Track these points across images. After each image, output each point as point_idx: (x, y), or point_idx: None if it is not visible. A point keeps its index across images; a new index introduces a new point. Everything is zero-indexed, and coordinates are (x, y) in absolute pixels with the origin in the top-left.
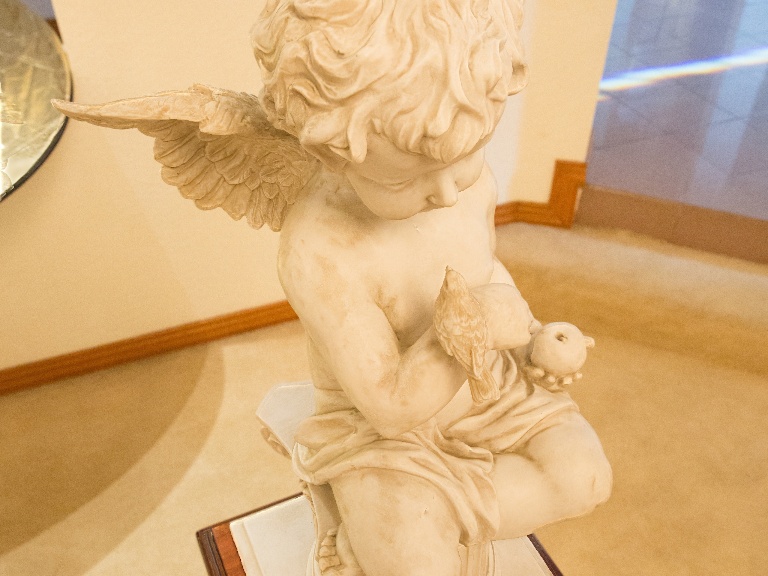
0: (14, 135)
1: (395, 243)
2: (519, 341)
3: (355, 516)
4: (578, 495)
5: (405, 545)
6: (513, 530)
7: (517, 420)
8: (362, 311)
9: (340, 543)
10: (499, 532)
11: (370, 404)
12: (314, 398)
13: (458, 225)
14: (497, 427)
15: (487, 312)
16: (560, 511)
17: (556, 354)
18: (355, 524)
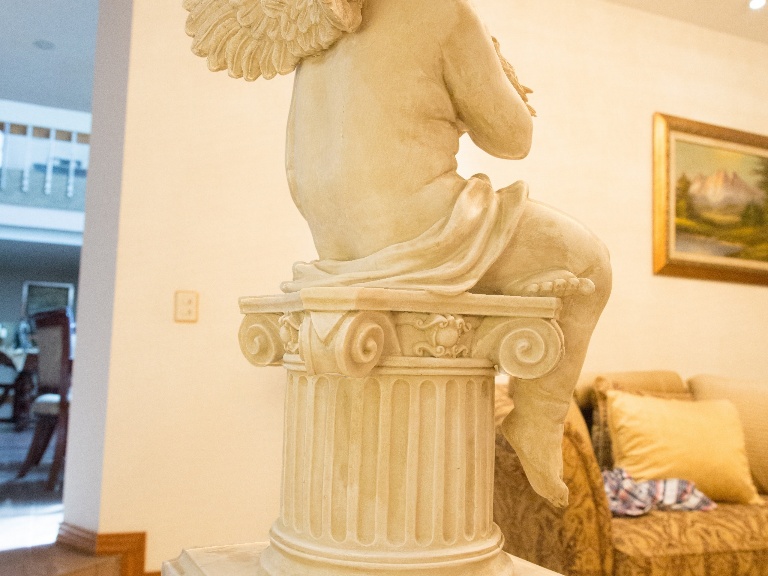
0: None
1: None
2: None
3: (560, 219)
4: None
5: None
6: None
7: None
8: None
9: (552, 275)
10: None
11: (529, 113)
12: (434, 194)
13: None
14: None
15: None
16: None
17: None
18: (564, 224)
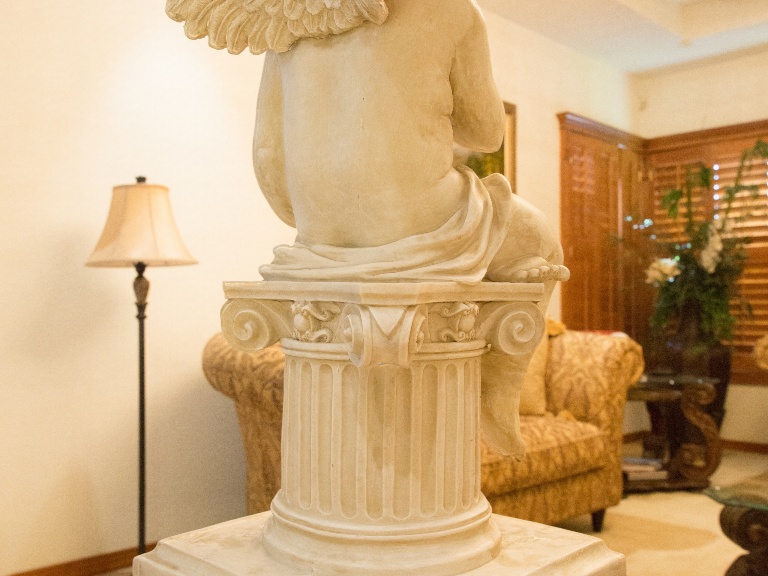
0: None
1: None
2: None
3: (533, 210)
4: None
5: None
6: None
7: None
8: None
9: (533, 262)
10: None
11: None
12: (448, 188)
13: None
14: None
15: None
16: None
17: None
18: None
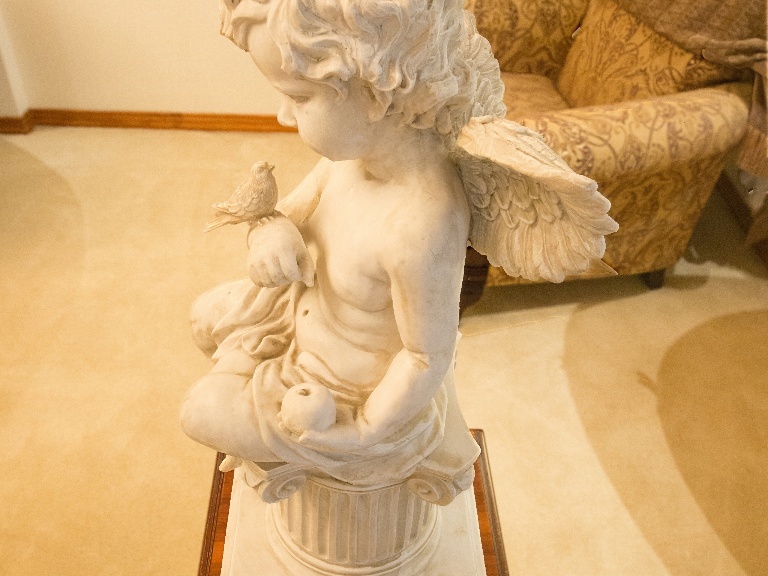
0: None
1: None
2: None
3: None
4: None
5: None
6: None
7: (264, 363)
8: (311, 179)
9: None
10: None
11: None
12: None
13: (353, 218)
14: (273, 359)
15: (265, 226)
16: None
17: None
18: None
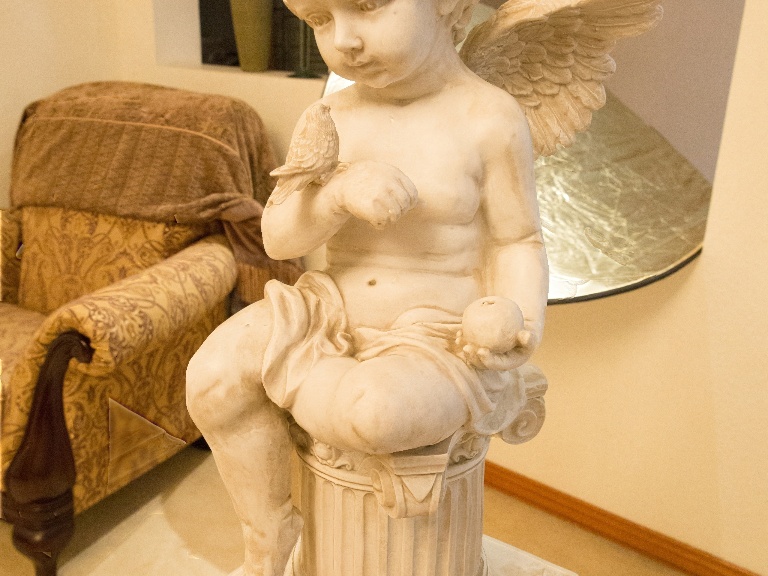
0: (610, 269)
1: (366, 120)
2: (360, 205)
3: None
4: (341, 398)
5: (217, 333)
6: (303, 413)
7: (385, 336)
8: None
9: None
10: (297, 409)
11: None
12: None
13: (427, 132)
14: None
15: (351, 168)
16: (329, 411)
17: (467, 310)
18: None
